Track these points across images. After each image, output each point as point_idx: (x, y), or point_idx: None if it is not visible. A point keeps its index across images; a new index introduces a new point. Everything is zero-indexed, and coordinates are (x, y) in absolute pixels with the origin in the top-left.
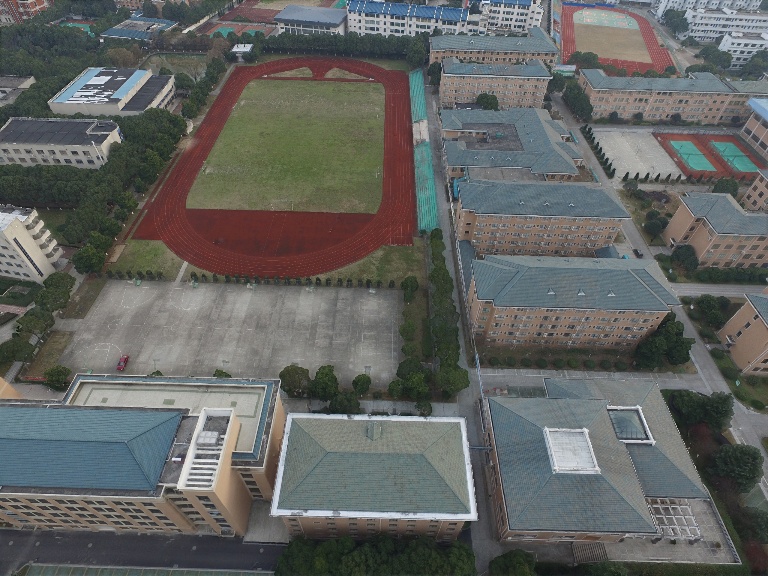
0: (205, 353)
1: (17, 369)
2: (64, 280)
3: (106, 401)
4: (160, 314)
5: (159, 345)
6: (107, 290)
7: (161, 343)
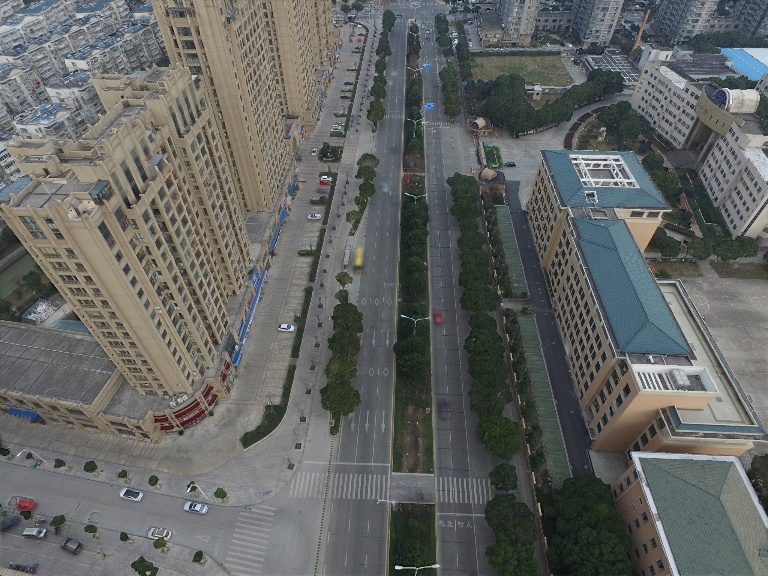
0: (746, 380)
1: (653, 256)
2: (751, 247)
3: (669, 304)
4: (764, 330)
5: (730, 339)
6: (760, 283)
7: (733, 340)
